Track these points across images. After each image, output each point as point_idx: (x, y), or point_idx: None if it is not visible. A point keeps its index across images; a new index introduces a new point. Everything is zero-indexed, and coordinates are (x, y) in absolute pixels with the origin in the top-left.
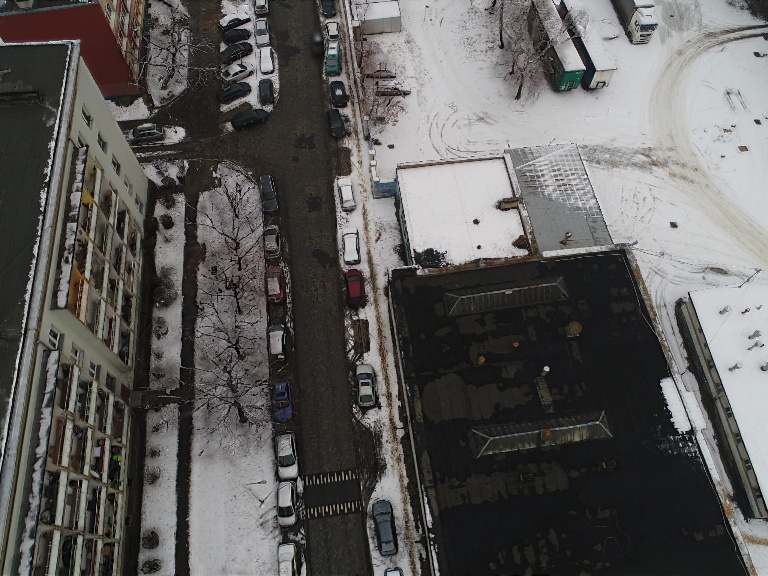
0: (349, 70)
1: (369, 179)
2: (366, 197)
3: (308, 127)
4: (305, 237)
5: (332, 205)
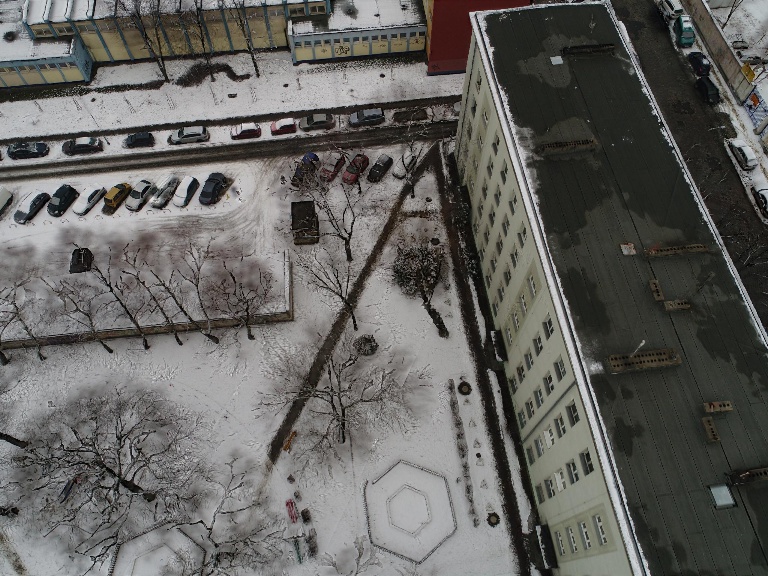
0: (699, 42)
1: (757, 141)
2: (760, 157)
3: (681, 94)
4: (718, 193)
5: (731, 165)
